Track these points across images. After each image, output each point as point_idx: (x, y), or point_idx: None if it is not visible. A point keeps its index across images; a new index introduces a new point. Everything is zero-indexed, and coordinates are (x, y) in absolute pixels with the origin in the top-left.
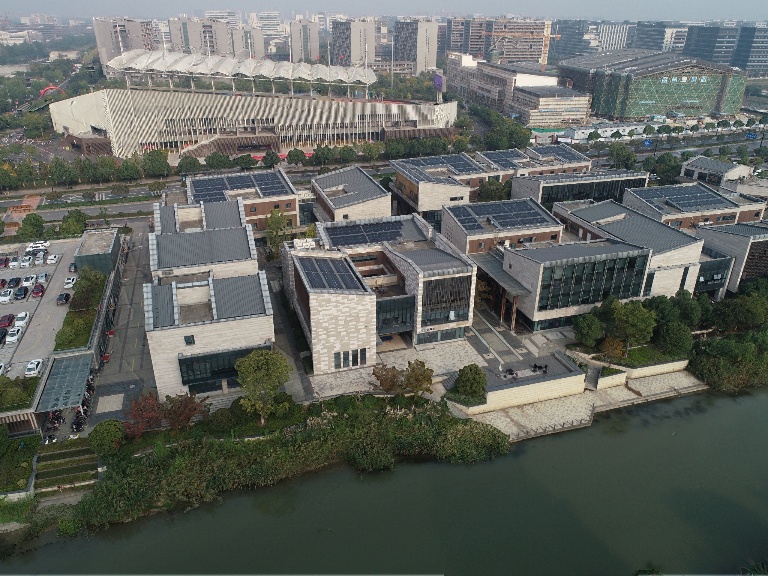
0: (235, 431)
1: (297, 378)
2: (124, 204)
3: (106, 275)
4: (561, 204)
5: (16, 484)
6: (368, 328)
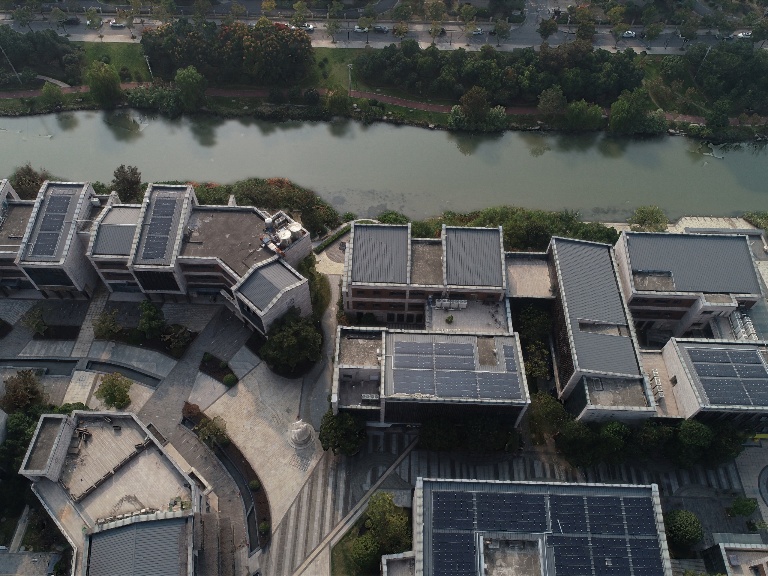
0: None
1: None
2: None
3: None
4: None
5: None
6: None
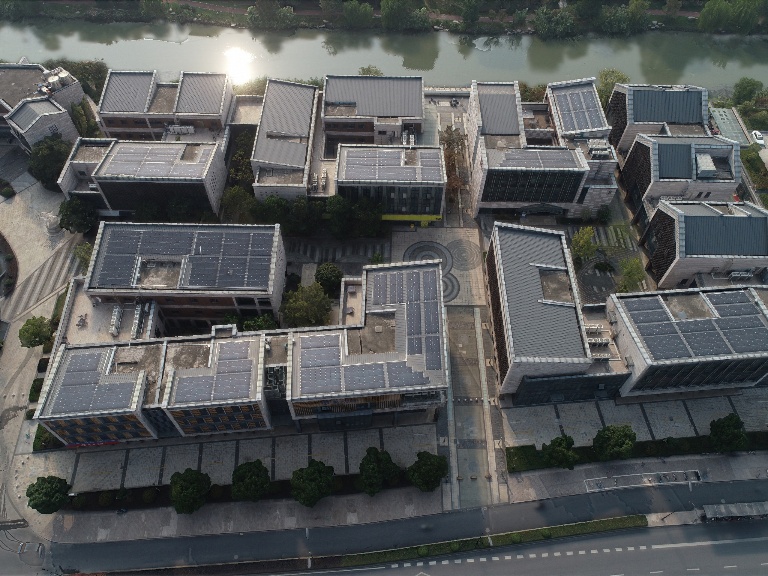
0: None
1: None
2: None
3: None
4: None
5: (718, 103)
6: None
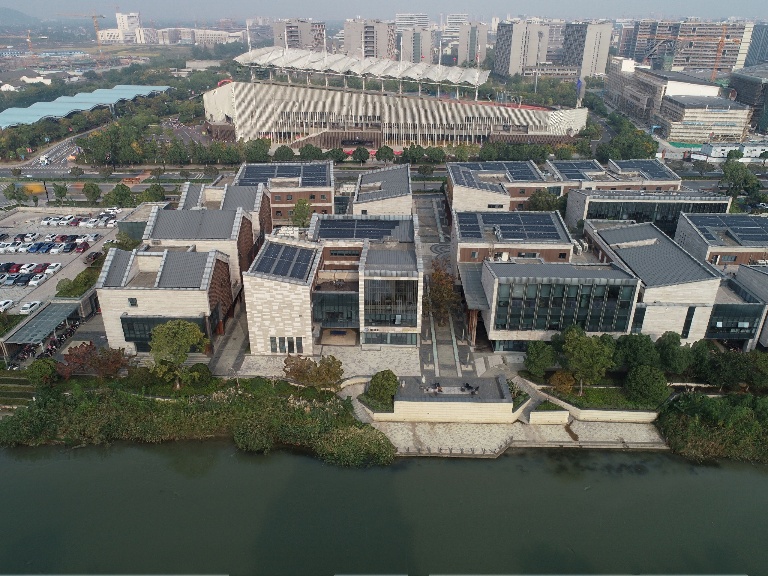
0: (151, 390)
1: (235, 354)
2: None
3: (140, 241)
4: (594, 222)
5: None
6: (303, 318)
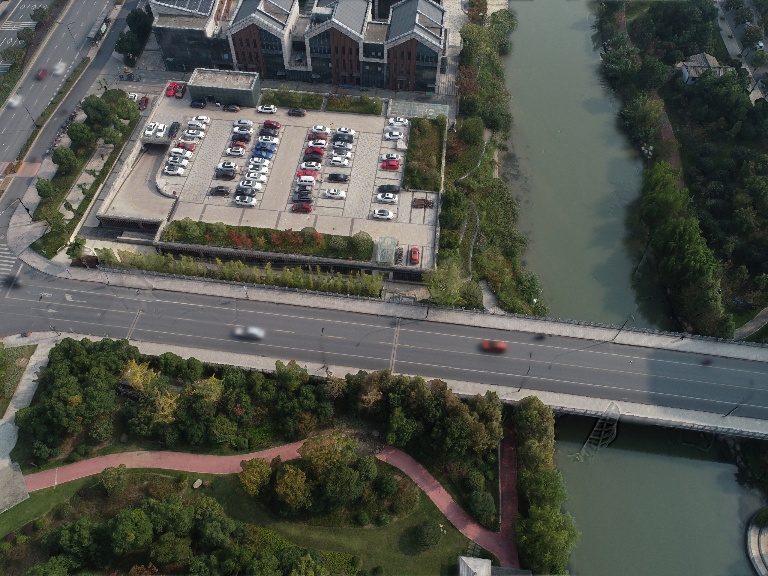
0: None
1: None
2: (13, 92)
3: None
4: None
5: None
6: None
